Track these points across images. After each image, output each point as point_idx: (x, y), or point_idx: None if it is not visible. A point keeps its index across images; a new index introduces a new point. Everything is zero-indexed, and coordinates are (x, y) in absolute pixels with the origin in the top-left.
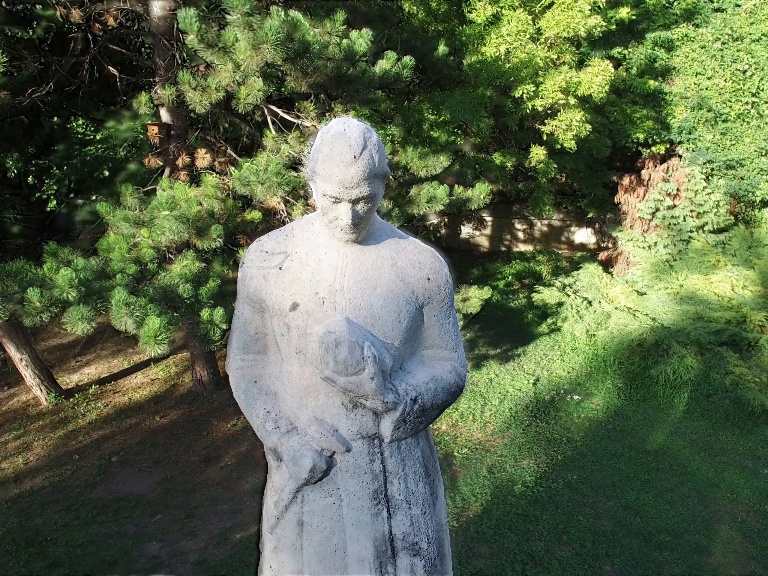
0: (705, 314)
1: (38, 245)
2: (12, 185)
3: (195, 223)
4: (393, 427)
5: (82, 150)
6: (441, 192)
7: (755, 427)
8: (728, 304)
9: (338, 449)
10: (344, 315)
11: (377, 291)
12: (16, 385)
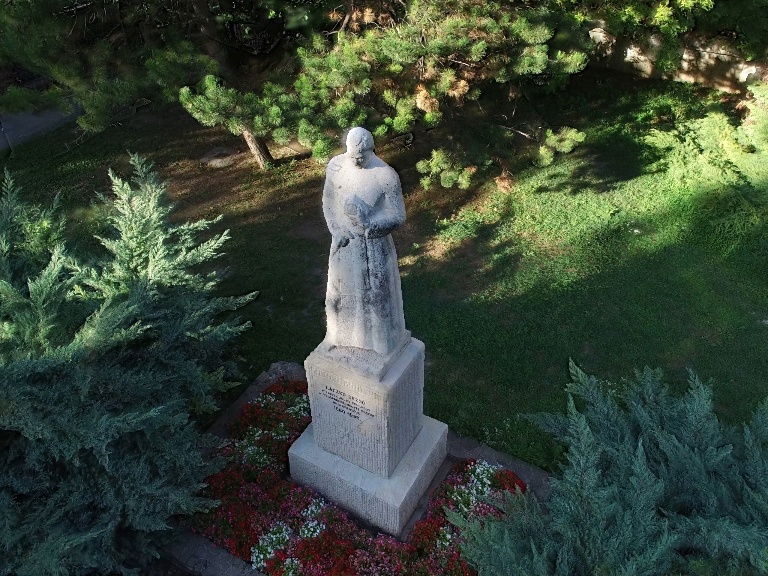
0: None
1: (262, 84)
2: (246, 4)
3: (355, 74)
4: (368, 234)
5: (291, 1)
6: (540, 60)
7: None
8: None
9: (350, 237)
10: (355, 193)
11: (367, 187)
12: None
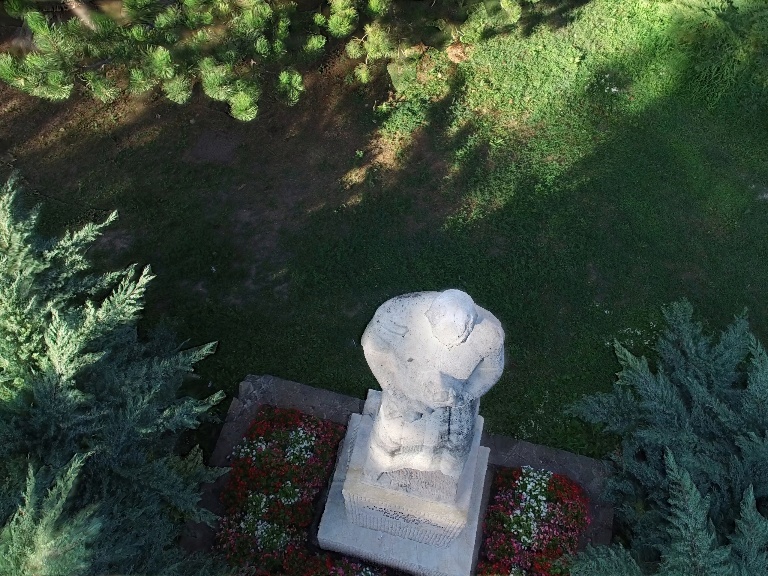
0: None
1: None
2: None
3: None
4: None
5: None
6: None
7: (767, 137)
8: None
9: None
10: (439, 370)
11: (459, 358)
12: None
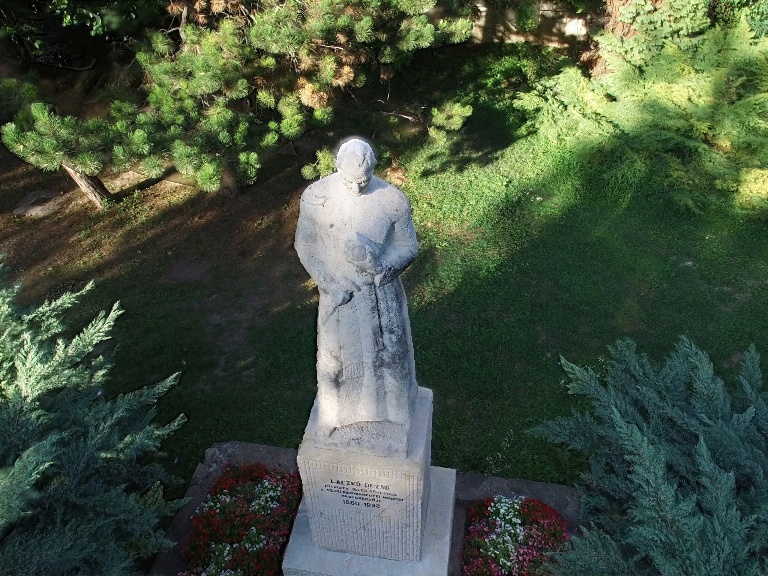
0: (660, 122)
1: (107, 104)
2: None
3: (223, 75)
4: (381, 280)
5: None
6: (427, 32)
7: (678, 222)
8: (683, 112)
9: (355, 290)
10: (356, 231)
11: (372, 218)
12: (69, 190)
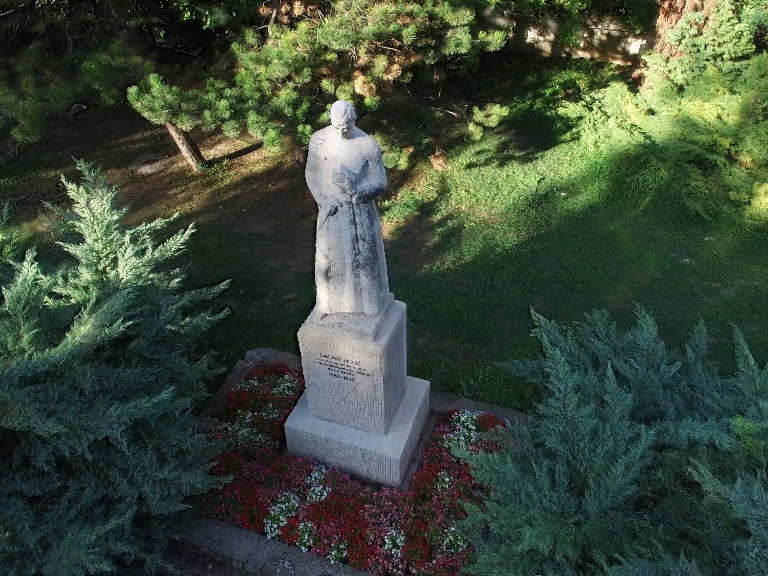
0: (688, 136)
1: (204, 79)
2: None
3: (294, 64)
4: (356, 200)
5: None
6: (465, 40)
7: (687, 225)
8: (712, 128)
9: (338, 205)
10: (341, 163)
11: (352, 155)
12: (173, 155)
